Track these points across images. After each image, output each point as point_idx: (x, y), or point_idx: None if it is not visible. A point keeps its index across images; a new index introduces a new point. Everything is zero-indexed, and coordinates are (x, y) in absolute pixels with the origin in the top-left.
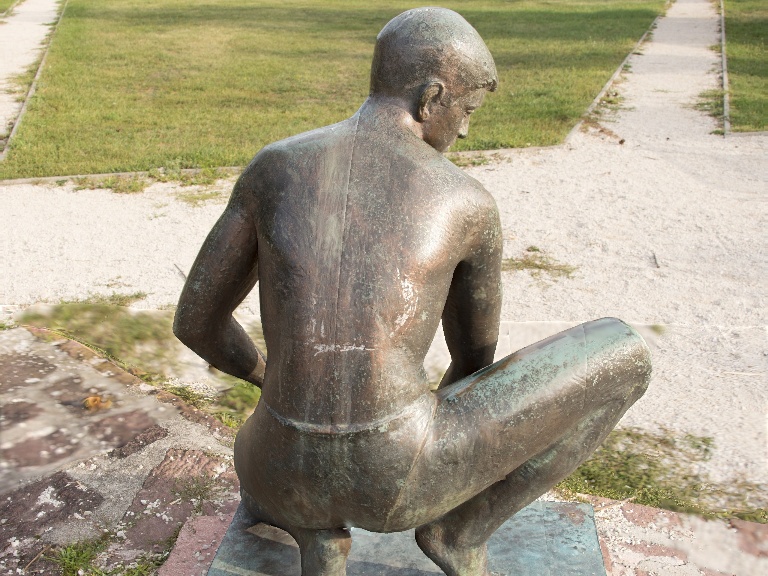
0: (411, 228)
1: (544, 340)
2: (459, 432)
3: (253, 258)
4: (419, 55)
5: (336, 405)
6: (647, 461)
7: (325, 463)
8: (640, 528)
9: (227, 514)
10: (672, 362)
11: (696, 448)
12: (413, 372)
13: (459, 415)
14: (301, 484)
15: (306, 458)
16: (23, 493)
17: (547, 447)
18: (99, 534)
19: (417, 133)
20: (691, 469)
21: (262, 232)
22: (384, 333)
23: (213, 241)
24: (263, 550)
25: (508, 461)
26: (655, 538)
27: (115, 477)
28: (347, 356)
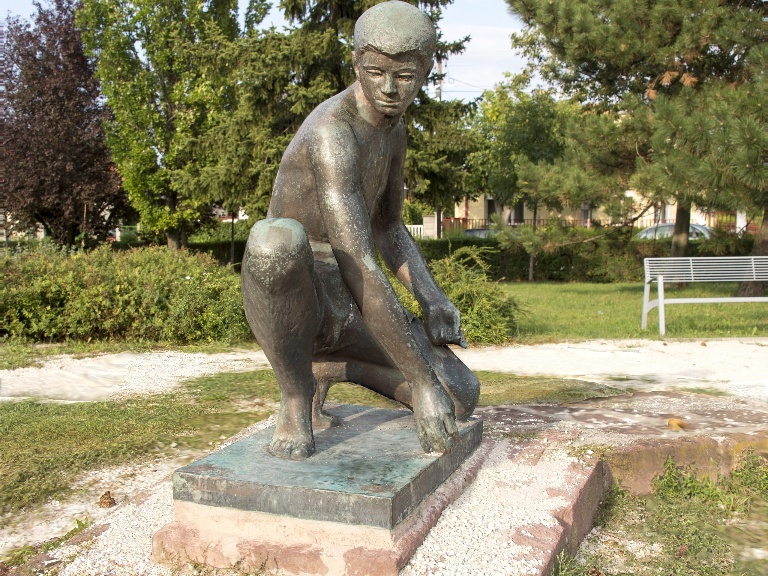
0: None
1: None
2: None
3: None
4: None
5: None
6: None
7: None
8: None
9: None
10: None
11: None
12: None
13: None
14: None
15: None
16: None
17: None
18: None
19: (359, 90)
20: None
21: None
22: None
23: None
24: None
25: None
26: None
27: None
28: None
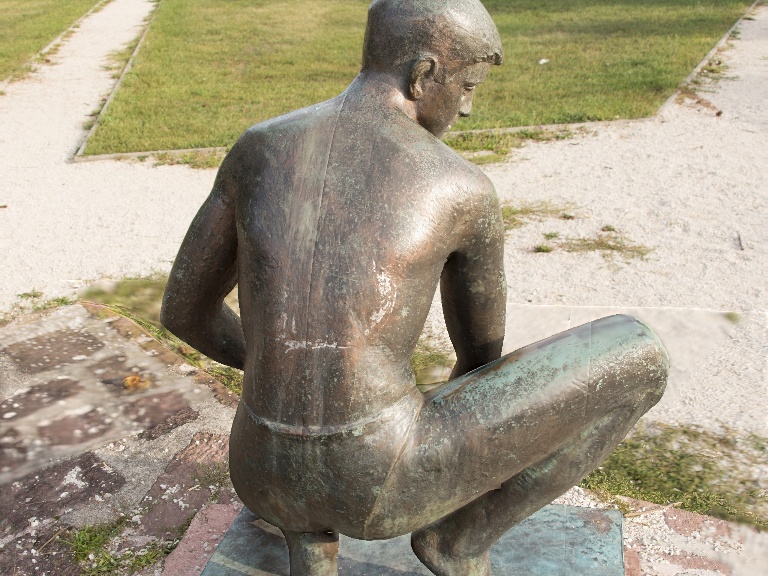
0: (390, 217)
1: (546, 339)
2: (443, 437)
3: (237, 246)
4: (408, 27)
5: (308, 405)
6: (702, 462)
7: (298, 465)
8: (682, 537)
9: (242, 503)
10: (744, 354)
11: (759, 450)
12: (393, 372)
13: (444, 419)
14: (276, 486)
15: (279, 459)
16: (51, 472)
17: (546, 455)
18: (115, 518)
19: (409, 112)
20: (751, 473)
21: (238, 219)
22: (358, 330)
23: (195, 227)
24: (265, 545)
25: (498, 470)
26: (697, 549)
27: (140, 459)
28: (319, 353)
